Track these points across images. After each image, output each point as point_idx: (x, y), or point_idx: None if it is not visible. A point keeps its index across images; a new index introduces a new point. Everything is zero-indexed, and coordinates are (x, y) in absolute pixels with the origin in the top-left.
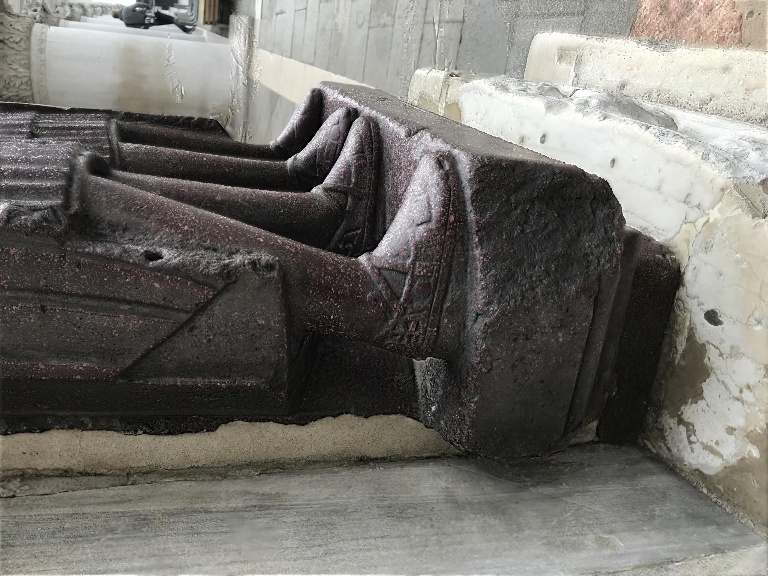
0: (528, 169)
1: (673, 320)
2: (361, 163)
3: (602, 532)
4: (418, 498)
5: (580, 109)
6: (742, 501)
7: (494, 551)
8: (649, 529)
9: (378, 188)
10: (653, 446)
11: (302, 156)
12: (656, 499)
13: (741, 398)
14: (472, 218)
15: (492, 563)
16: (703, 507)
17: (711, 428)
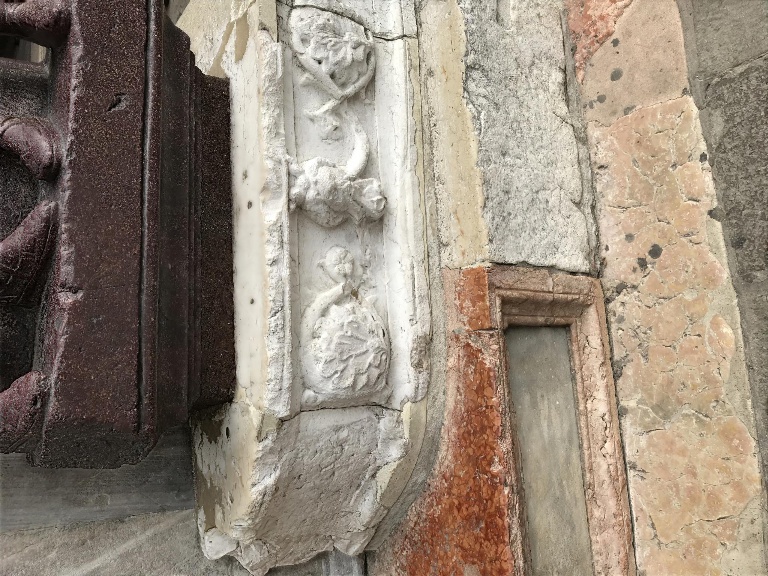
0: (94, 425)
1: (220, 407)
2: (29, 259)
3: (105, 492)
4: (2, 455)
5: (272, 229)
6: (198, 486)
7: (29, 503)
8: (135, 492)
9: (42, 273)
10: (191, 424)
11: (7, 142)
12: (158, 468)
13: (216, 467)
14: (43, 437)
15: (22, 511)
16: (182, 476)
17: (206, 455)
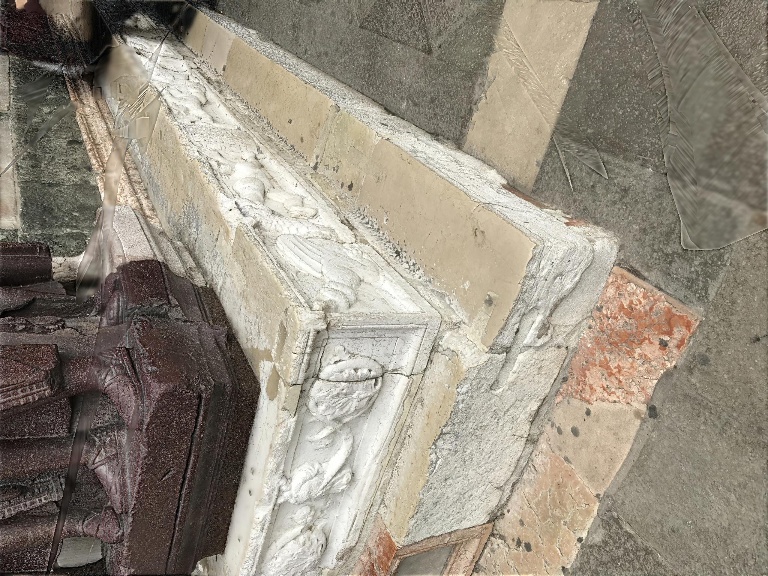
0: None
1: None
2: None
3: None
4: None
5: None
6: None
7: None
8: None
9: None
10: None
11: None
12: None
13: None
14: None
15: None
16: None
17: None
